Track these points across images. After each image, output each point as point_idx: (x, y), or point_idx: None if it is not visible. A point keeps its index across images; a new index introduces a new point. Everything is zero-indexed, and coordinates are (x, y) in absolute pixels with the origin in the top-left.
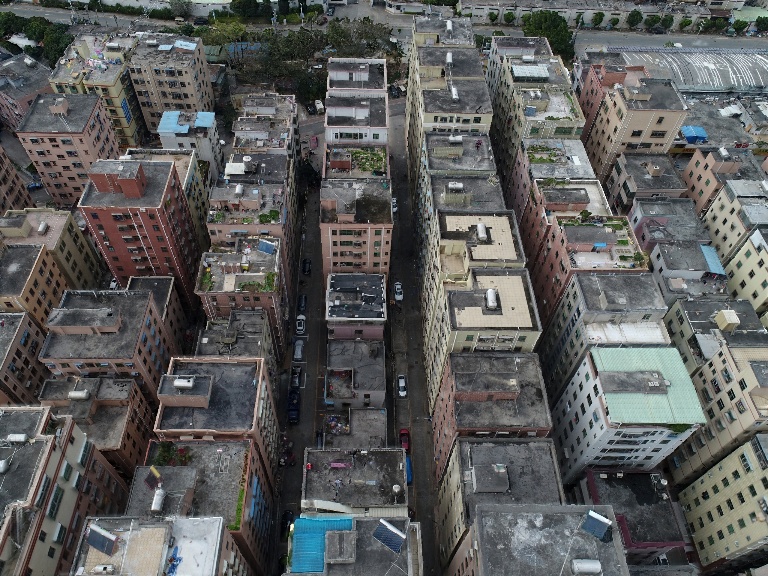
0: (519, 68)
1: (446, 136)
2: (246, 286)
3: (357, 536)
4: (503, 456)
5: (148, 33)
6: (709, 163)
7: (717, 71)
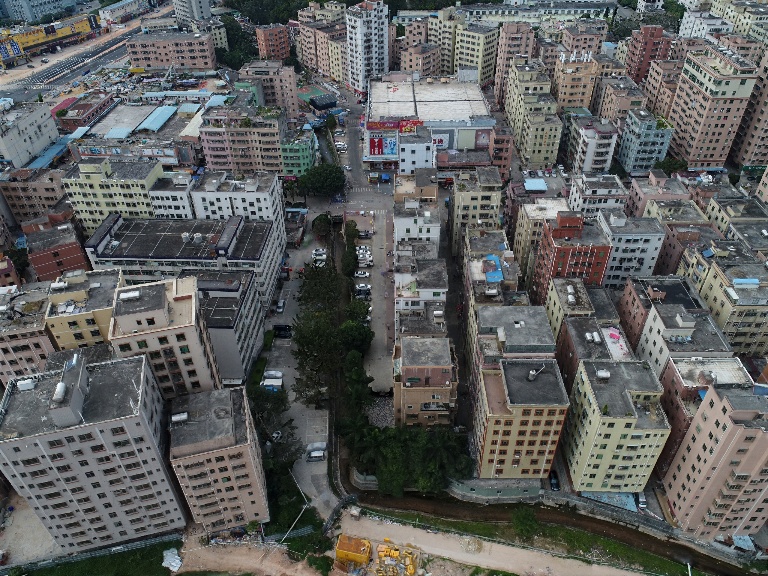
0: None
1: None
2: None
3: None
4: None
5: None
6: None
7: None
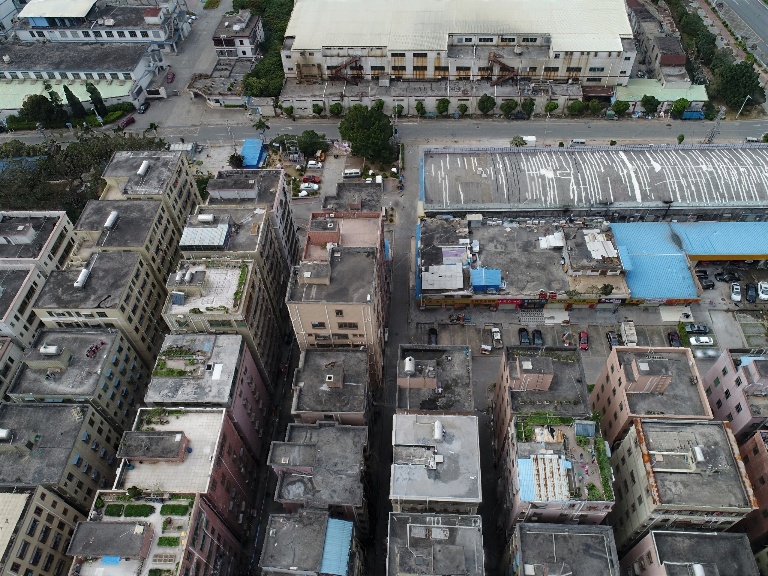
0: (191, 232)
1: (67, 334)
2: None
3: None
4: None
5: None
6: None
7: (554, 181)
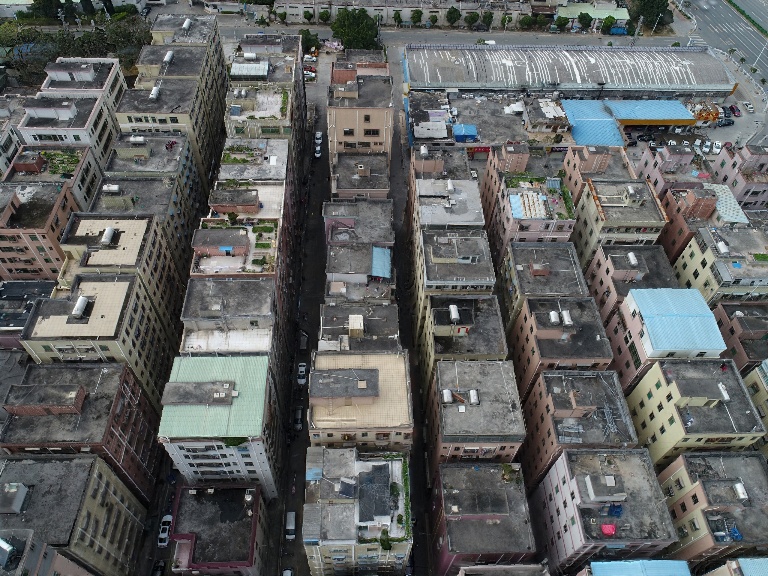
0: (238, 66)
1: None
2: None
3: None
4: (35, 474)
5: None
6: None
7: (513, 68)
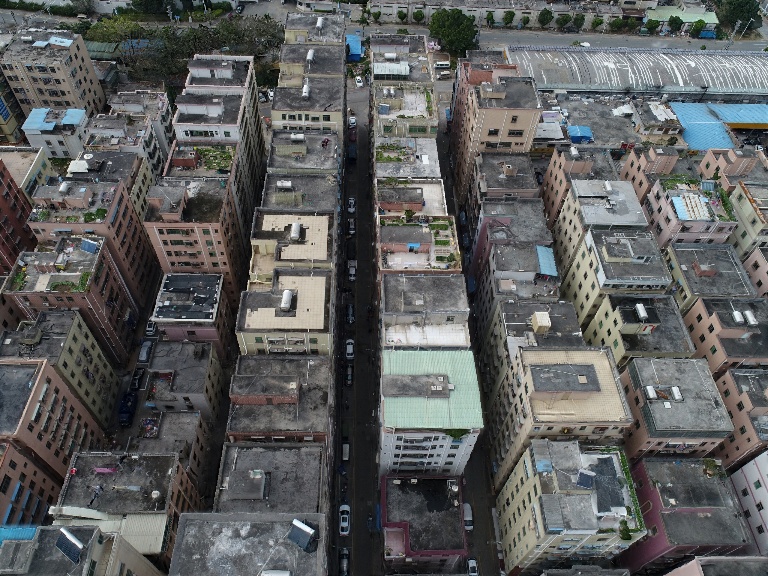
0: (380, 66)
1: None
2: (58, 286)
3: (34, 546)
4: (269, 461)
5: (41, 30)
6: (562, 163)
7: (616, 70)
